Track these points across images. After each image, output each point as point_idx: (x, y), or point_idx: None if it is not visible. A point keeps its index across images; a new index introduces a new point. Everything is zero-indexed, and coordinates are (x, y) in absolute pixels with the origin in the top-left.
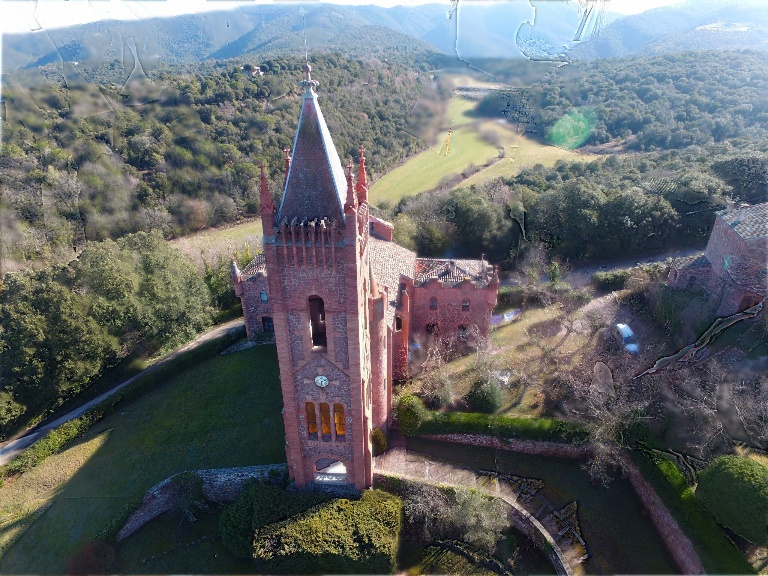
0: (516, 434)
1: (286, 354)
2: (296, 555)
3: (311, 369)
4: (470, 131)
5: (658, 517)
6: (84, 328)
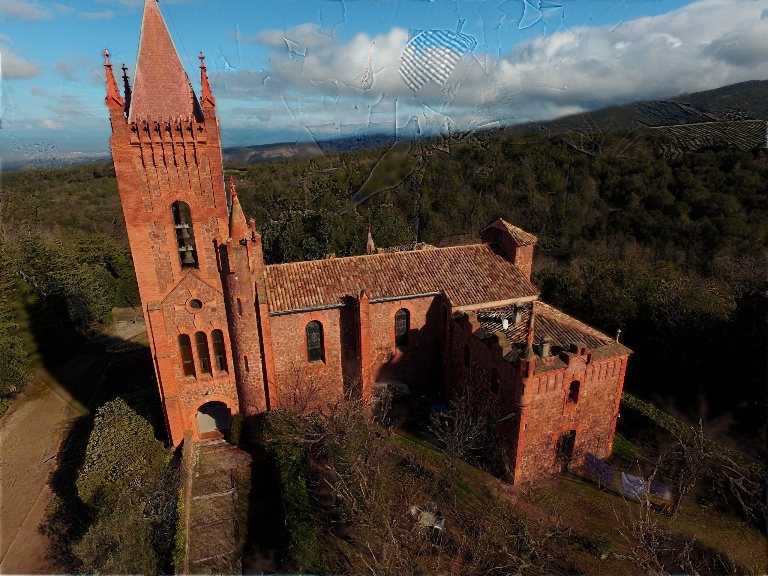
0: None
1: None
2: None
3: None
4: (355, 29)
5: None
6: (286, 251)
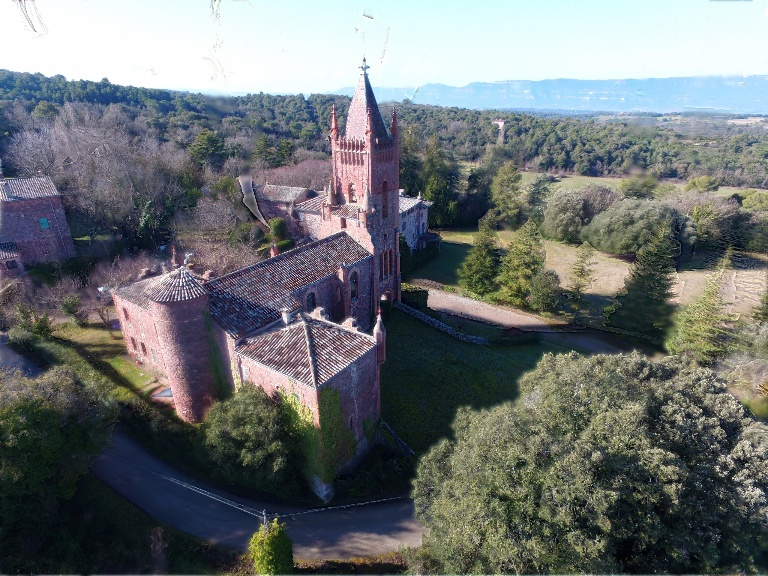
0: None
1: None
2: None
3: None
4: None
5: None
6: None
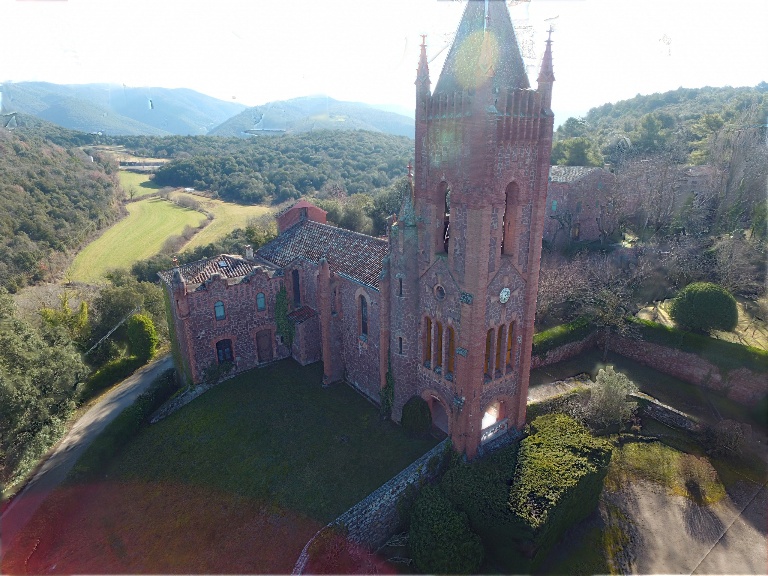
0: (550, 345)
1: (486, 264)
2: (561, 499)
3: (498, 282)
4: None
5: (656, 359)
6: None
